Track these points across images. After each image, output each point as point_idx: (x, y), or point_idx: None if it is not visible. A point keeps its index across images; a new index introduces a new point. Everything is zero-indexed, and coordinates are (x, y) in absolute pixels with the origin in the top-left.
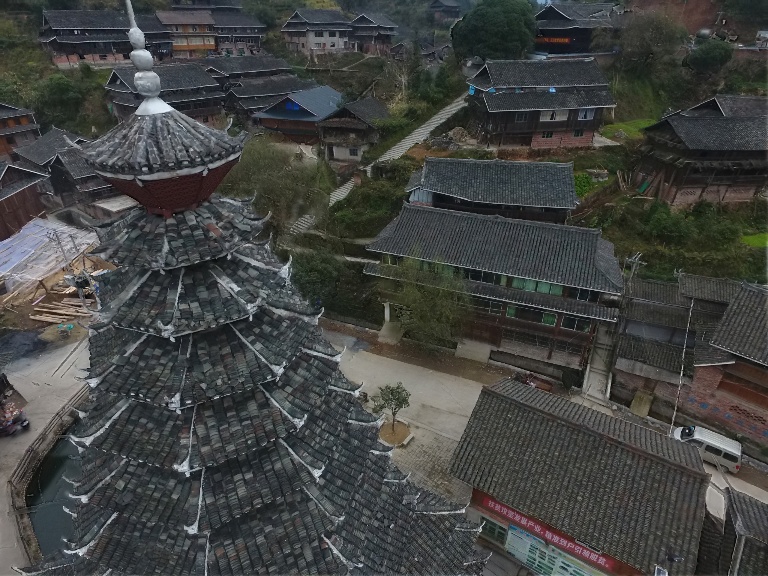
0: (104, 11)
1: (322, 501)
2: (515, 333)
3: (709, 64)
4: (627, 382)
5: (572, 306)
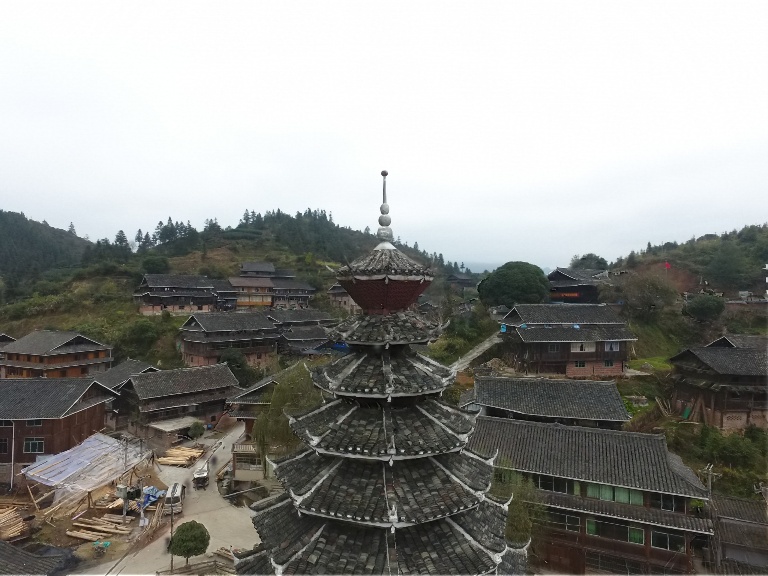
0: (191, 276)
1: None
2: (600, 558)
3: (707, 313)
4: None
5: (658, 517)
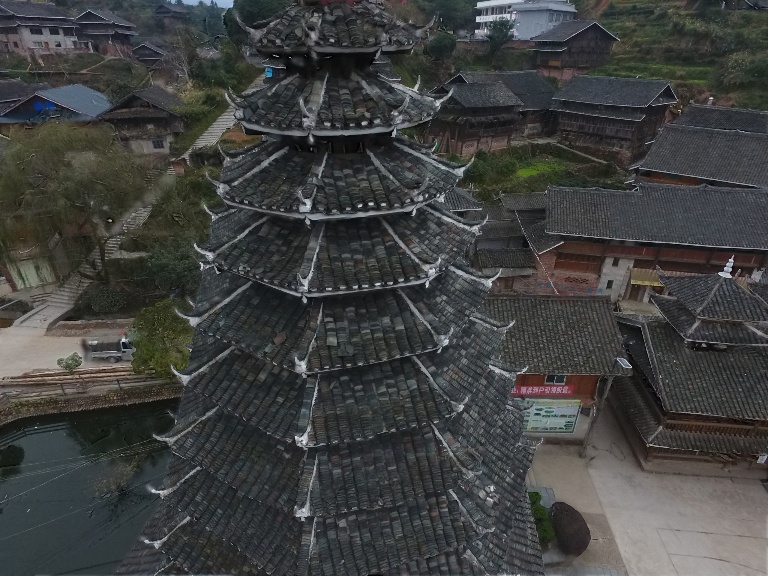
0: None
1: (487, 319)
2: None
3: (443, 51)
4: (492, 288)
5: None
